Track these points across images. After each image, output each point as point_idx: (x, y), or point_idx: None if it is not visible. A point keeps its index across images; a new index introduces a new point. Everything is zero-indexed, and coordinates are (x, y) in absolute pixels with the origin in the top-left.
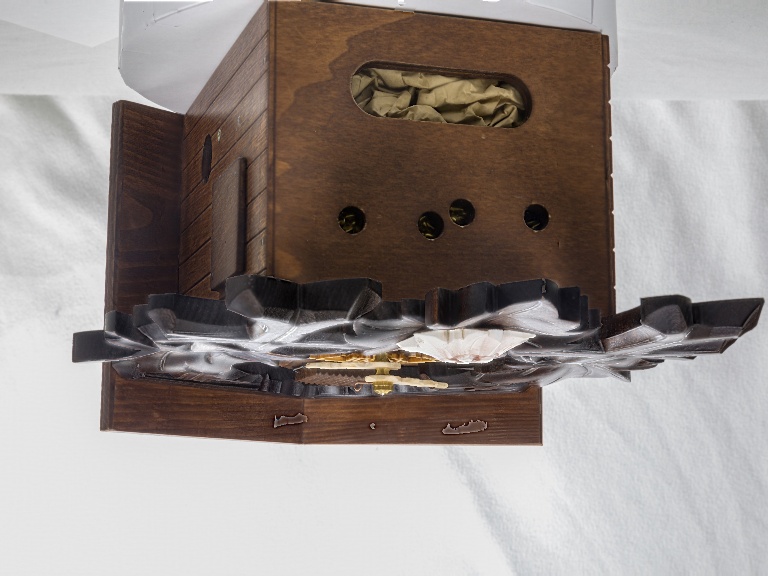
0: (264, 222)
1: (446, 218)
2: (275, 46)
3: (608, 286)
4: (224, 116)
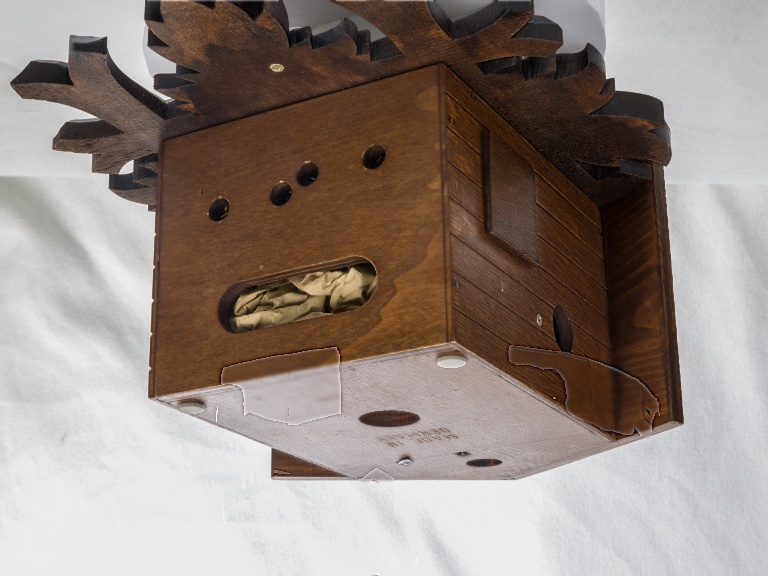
0: (450, 134)
1: (295, 184)
2: (446, 294)
3: (163, 170)
4: (532, 328)
